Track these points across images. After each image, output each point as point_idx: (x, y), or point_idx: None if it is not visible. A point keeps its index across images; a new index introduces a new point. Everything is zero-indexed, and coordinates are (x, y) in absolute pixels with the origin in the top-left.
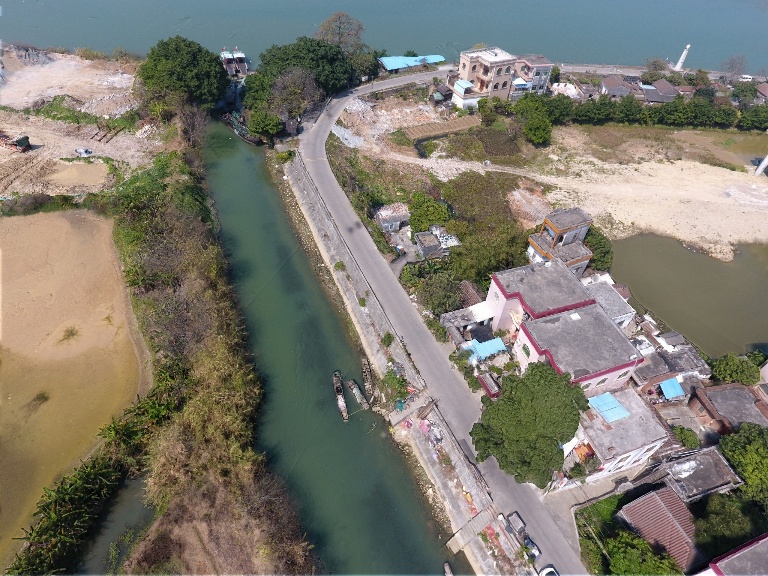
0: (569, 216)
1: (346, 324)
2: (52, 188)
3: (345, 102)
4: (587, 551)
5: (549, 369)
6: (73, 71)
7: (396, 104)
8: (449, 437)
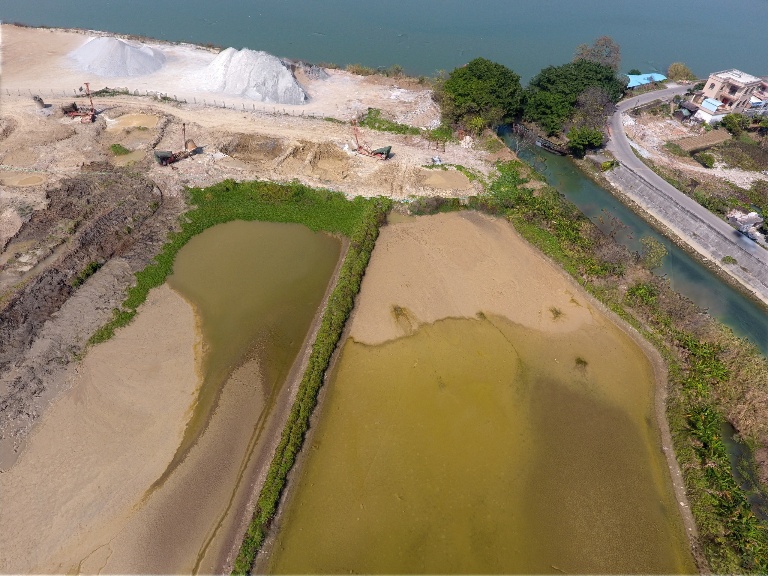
0: None
1: (764, 307)
2: (439, 192)
3: (618, 117)
4: None
5: None
6: (355, 86)
7: (649, 119)
8: None
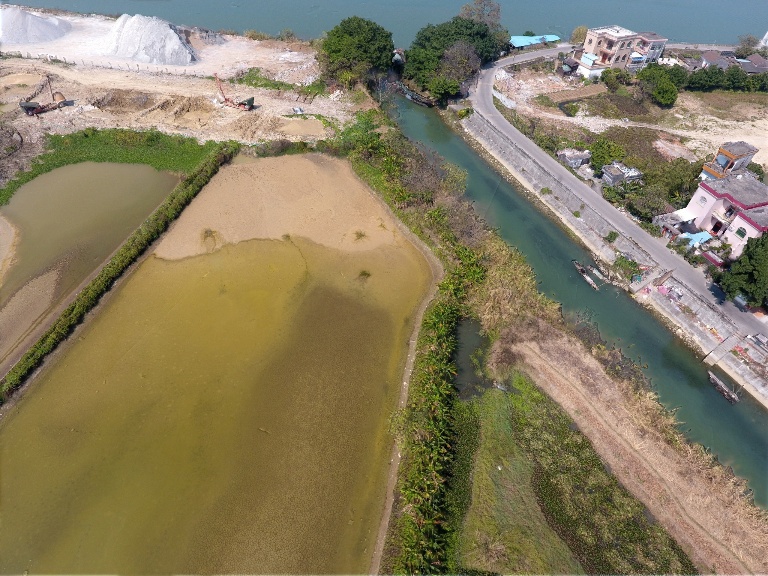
0: (737, 147)
1: (566, 231)
2: (289, 136)
3: (493, 72)
4: None
5: None
6: (248, 49)
7: (530, 75)
8: (689, 293)
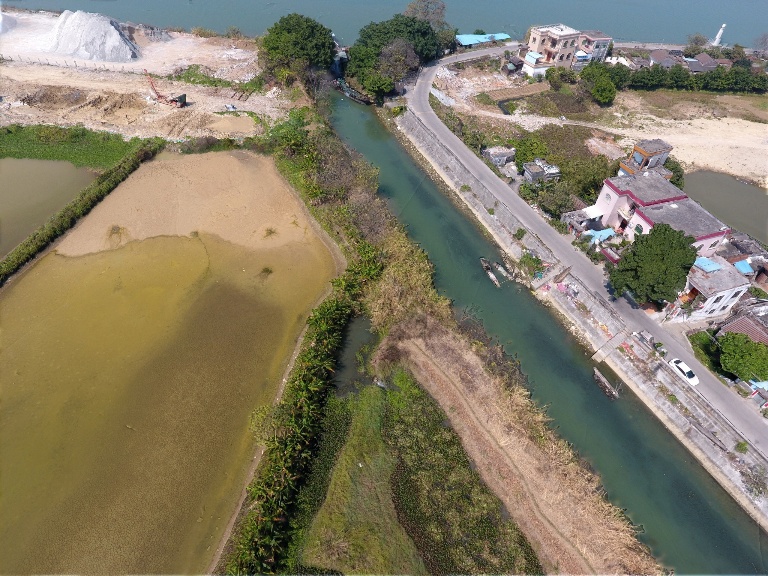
0: (653, 145)
1: (479, 228)
2: (216, 133)
3: (435, 70)
4: (698, 354)
5: (670, 227)
6: (193, 46)
7: (475, 73)
8: (585, 290)
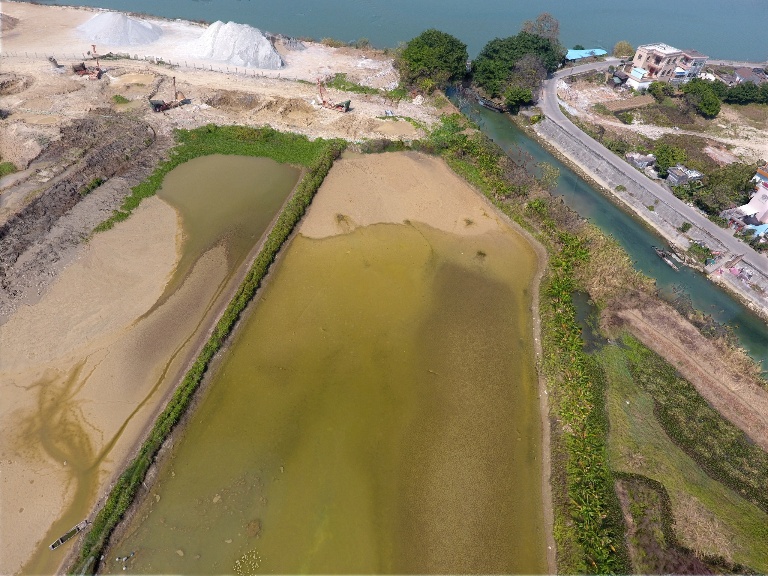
0: None
1: (642, 222)
2: (387, 136)
3: (554, 82)
4: None
5: None
6: (327, 56)
7: (584, 86)
8: (759, 274)
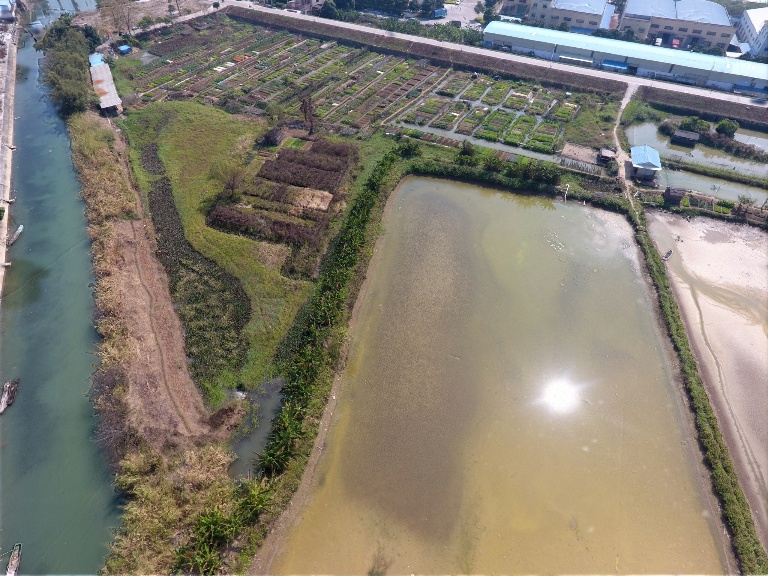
0: None
1: None
2: None
3: None
4: None
5: None
6: None
7: None
8: None
